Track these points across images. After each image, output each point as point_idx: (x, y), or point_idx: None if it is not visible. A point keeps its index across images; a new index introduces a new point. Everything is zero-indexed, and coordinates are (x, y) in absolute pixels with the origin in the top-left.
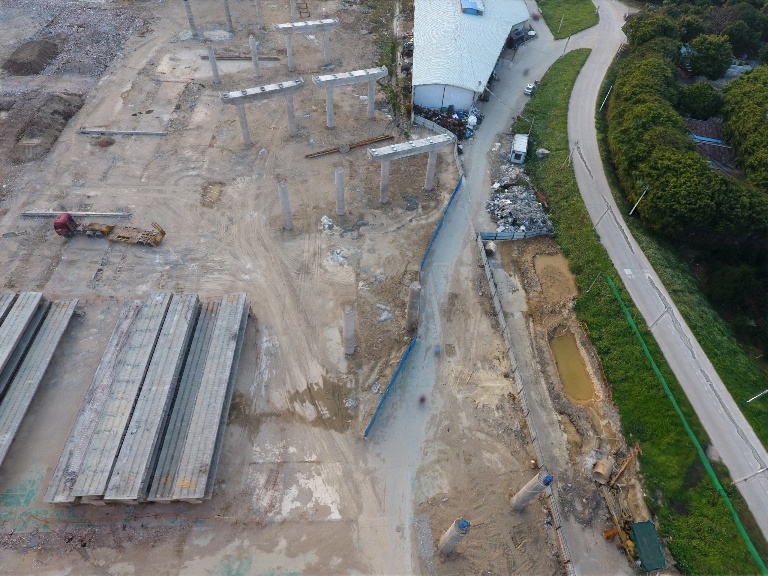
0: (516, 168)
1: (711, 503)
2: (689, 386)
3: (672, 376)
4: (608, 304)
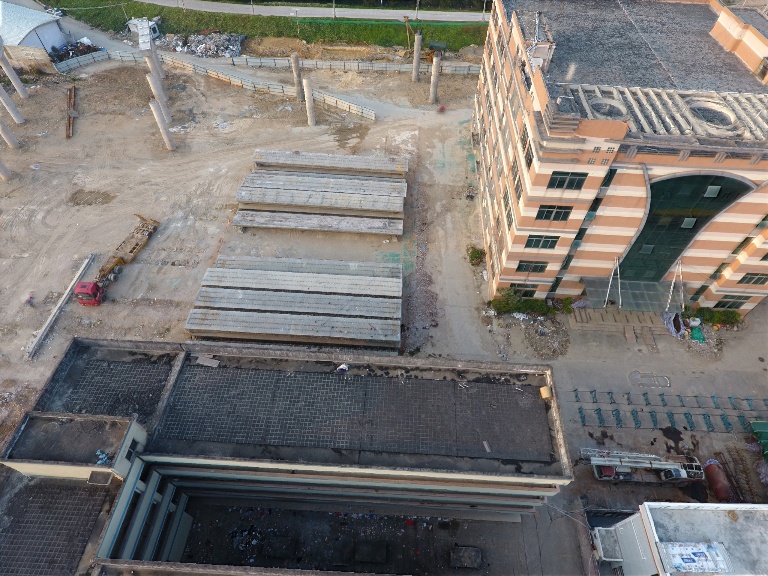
0: (166, 35)
1: (422, 29)
2: (369, 17)
3: (363, 19)
4: (311, 27)
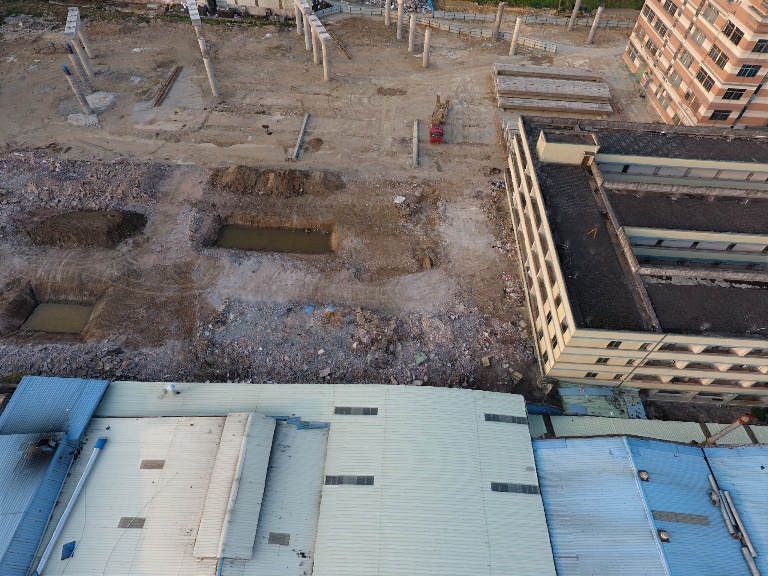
0: None
1: None
2: None
3: None
4: None
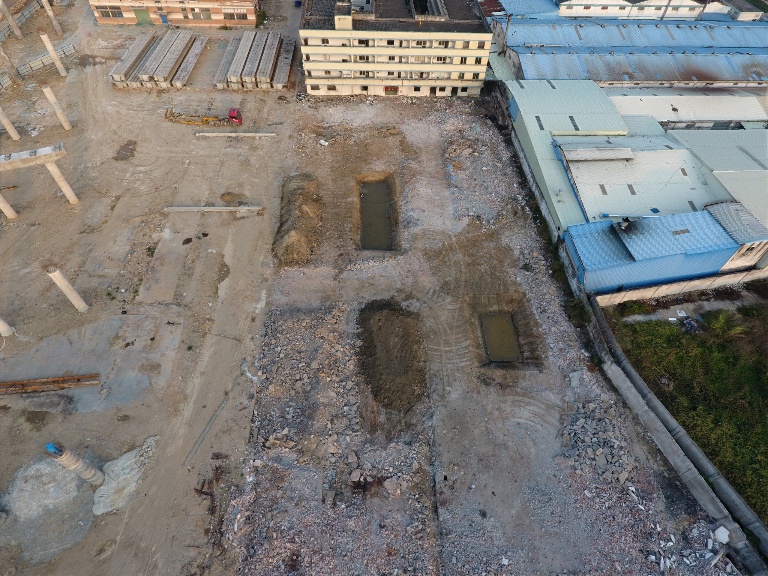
0: None
1: None
2: None
3: None
4: None
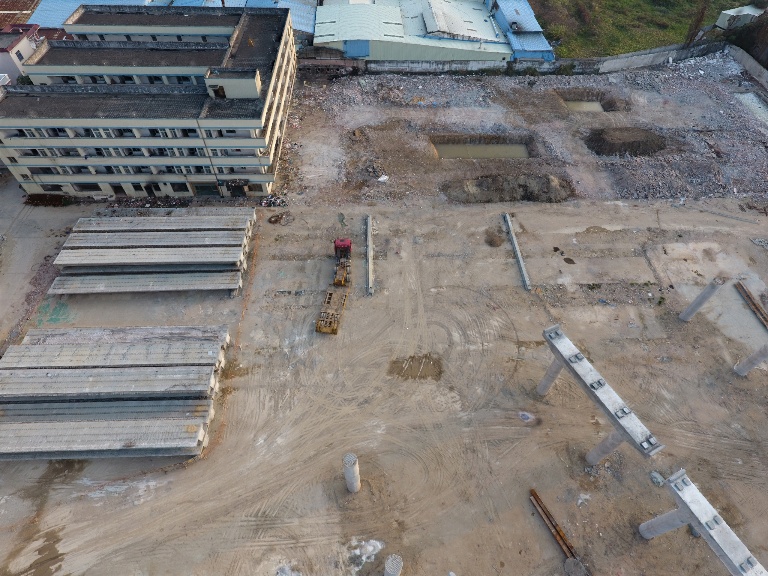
0: None
1: None
2: None
3: None
4: None
